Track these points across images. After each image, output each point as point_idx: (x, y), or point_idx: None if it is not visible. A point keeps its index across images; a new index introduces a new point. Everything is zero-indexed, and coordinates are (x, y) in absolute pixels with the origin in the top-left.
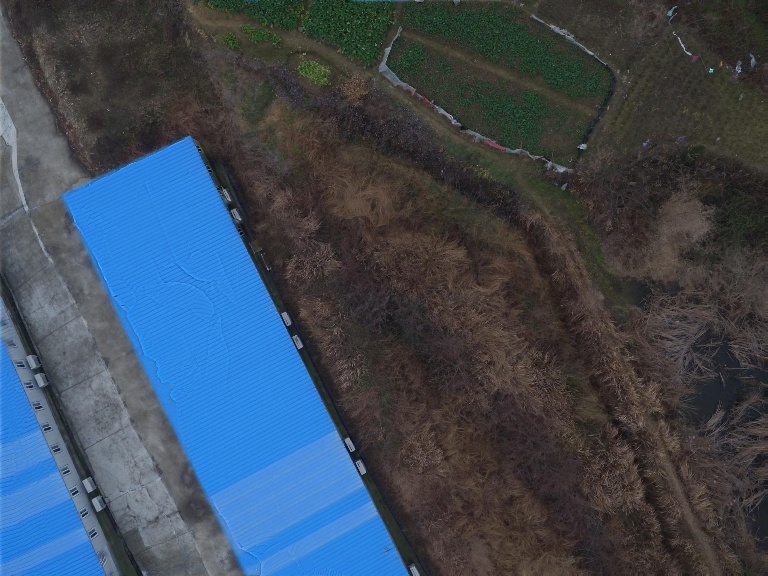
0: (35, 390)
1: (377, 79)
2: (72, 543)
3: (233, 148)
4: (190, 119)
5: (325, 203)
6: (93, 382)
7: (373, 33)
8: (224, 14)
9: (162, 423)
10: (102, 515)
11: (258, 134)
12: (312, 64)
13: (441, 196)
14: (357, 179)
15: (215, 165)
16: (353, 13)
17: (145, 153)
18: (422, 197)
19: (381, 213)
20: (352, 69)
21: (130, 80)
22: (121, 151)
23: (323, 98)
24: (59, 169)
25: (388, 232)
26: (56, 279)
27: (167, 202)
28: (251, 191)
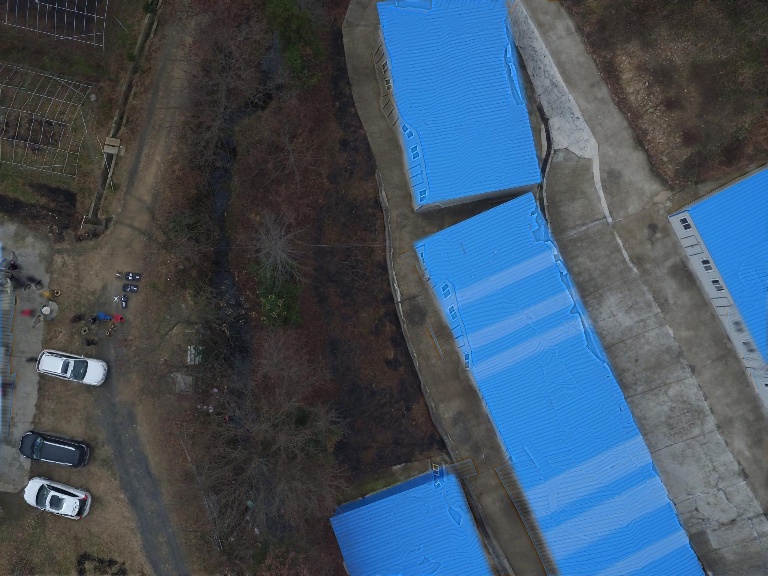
0: None
1: None
2: (673, 545)
3: None
4: None
5: None
6: (671, 389)
7: None
8: None
9: (747, 429)
10: None
11: None
12: None
13: None
14: None
15: None
16: None
17: (727, 168)
18: None
19: None
20: None
21: (723, 97)
22: (708, 166)
23: None
24: (640, 182)
25: None
26: (639, 289)
27: None
28: None
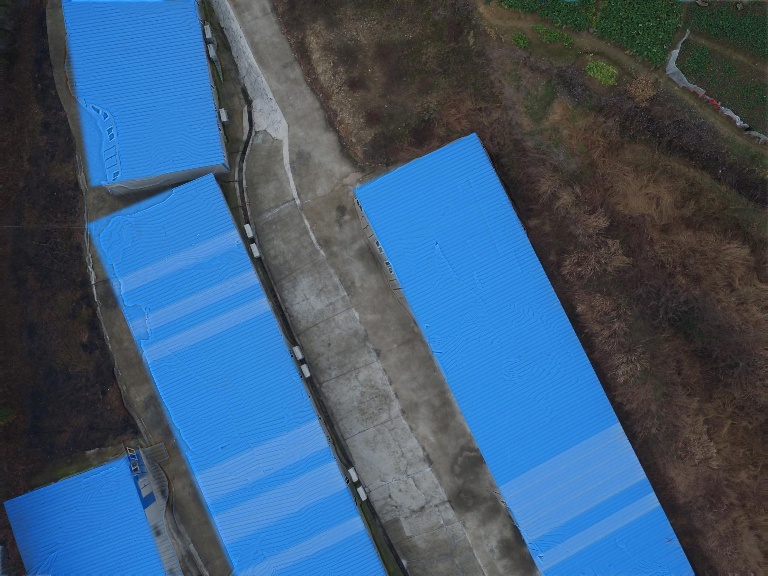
0: (303, 380)
1: (663, 80)
2: (349, 531)
3: (508, 145)
4: (463, 116)
5: (610, 201)
6: (360, 373)
7: (663, 35)
8: (516, 14)
9: (433, 414)
10: (363, 504)
11: (542, 132)
12: (600, 65)
13: (721, 195)
14: (639, 178)
15: None
16: (644, 15)
17: (416, 149)
18: (704, 196)
19: (664, 211)
20: (639, 70)
21: (407, 77)
22: (395, 147)
23: (608, 98)
24: (330, 163)
25: (671, 230)
26: (326, 271)
27: (490, 197)
28: (529, 188)
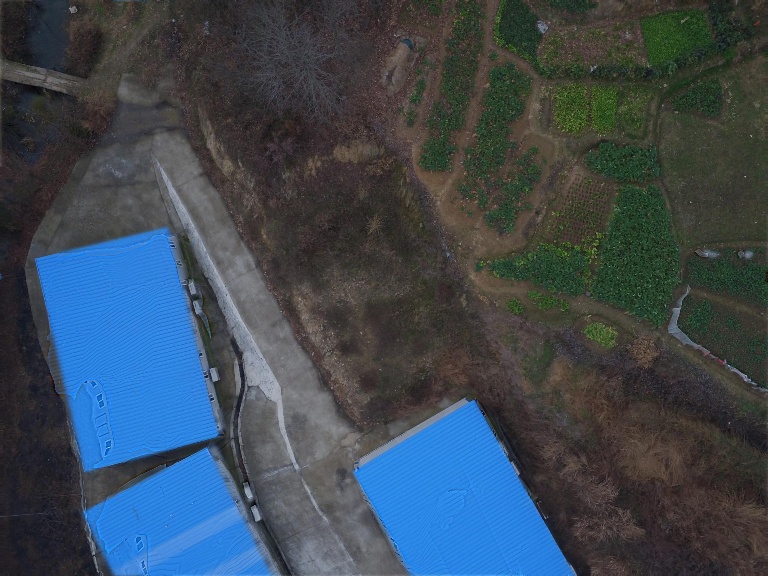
0: None
1: (666, 339)
2: None
3: (509, 402)
4: (460, 371)
5: (617, 465)
6: None
7: (663, 296)
8: (509, 282)
9: None
10: None
11: (543, 396)
12: (599, 327)
13: (732, 450)
14: (645, 436)
15: (494, 422)
16: (642, 276)
17: (415, 406)
18: (714, 454)
19: (674, 472)
20: (640, 329)
21: (401, 338)
22: (392, 407)
23: (610, 358)
24: (327, 425)
25: (682, 491)
26: (330, 536)
27: (494, 505)
28: (533, 448)
